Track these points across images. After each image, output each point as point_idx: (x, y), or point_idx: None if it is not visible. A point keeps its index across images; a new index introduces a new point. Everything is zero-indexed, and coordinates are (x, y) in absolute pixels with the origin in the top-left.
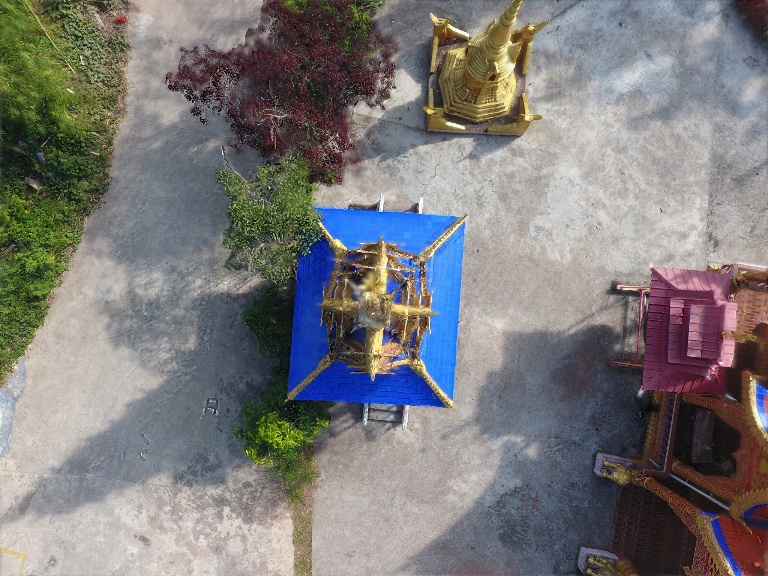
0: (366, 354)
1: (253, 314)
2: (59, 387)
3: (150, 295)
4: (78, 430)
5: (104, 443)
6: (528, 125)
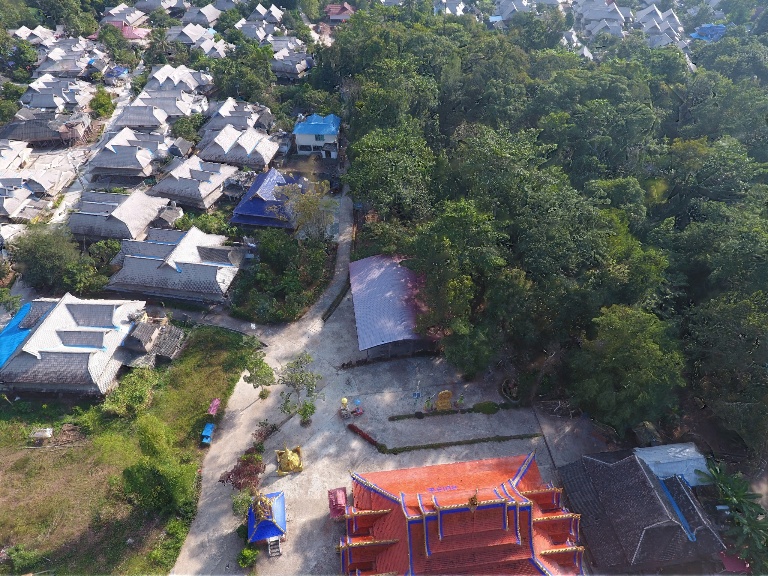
0: (258, 505)
1: (238, 529)
2: (183, 574)
3: (209, 539)
4: None
5: None
6: None
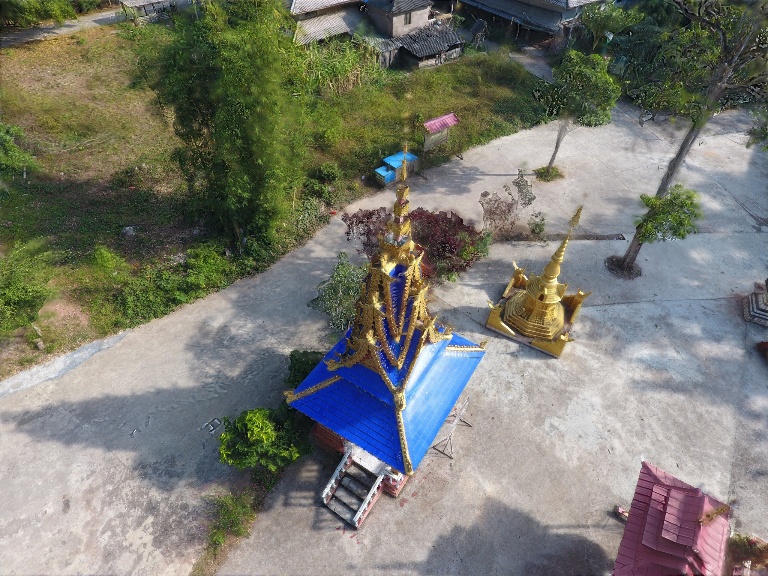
0: (378, 271)
1: (299, 354)
2: (132, 357)
3: (237, 334)
4: (113, 390)
5: (120, 408)
6: (563, 346)
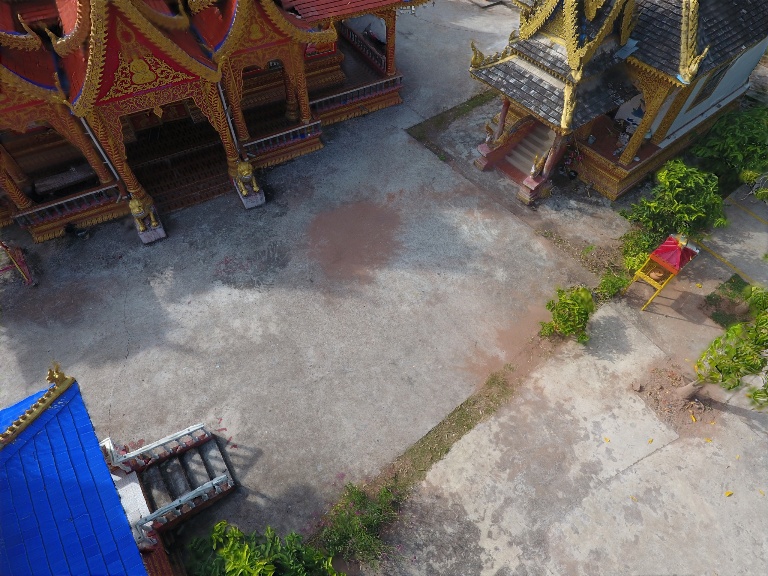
0: None
1: None
2: None
3: None
4: None
5: None
6: None
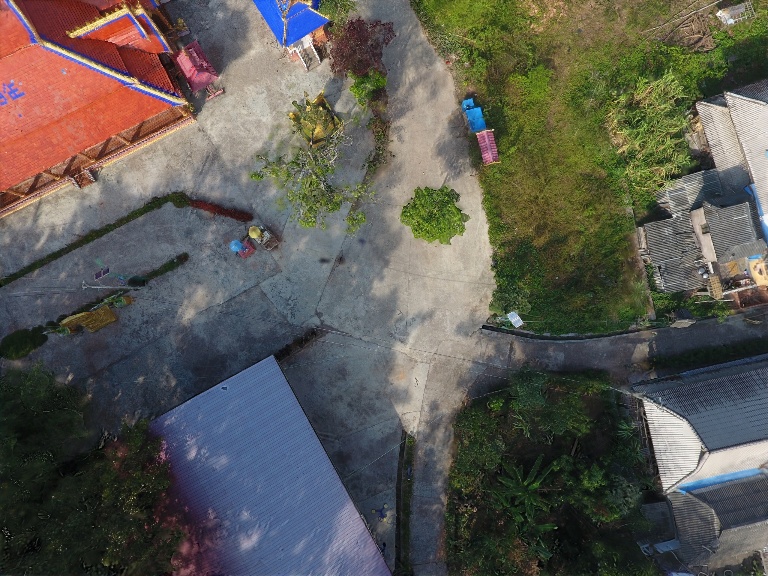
0: None
1: None
2: None
3: None
4: None
5: None
6: None
